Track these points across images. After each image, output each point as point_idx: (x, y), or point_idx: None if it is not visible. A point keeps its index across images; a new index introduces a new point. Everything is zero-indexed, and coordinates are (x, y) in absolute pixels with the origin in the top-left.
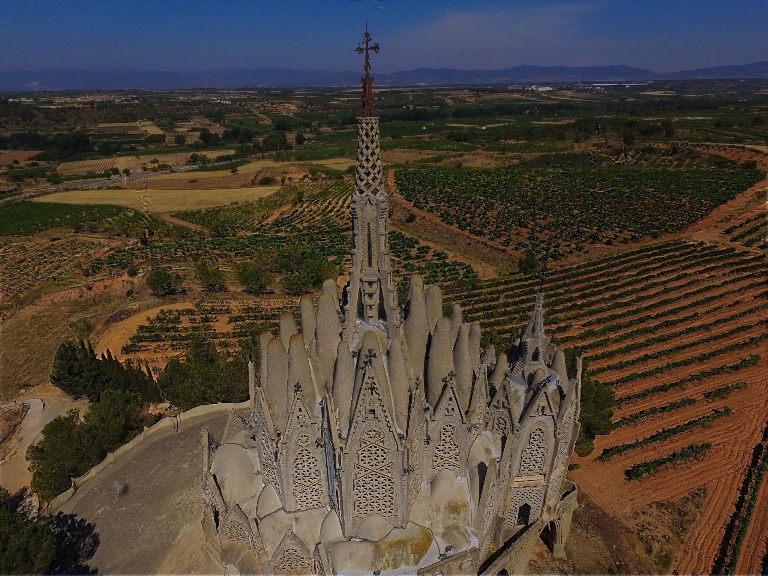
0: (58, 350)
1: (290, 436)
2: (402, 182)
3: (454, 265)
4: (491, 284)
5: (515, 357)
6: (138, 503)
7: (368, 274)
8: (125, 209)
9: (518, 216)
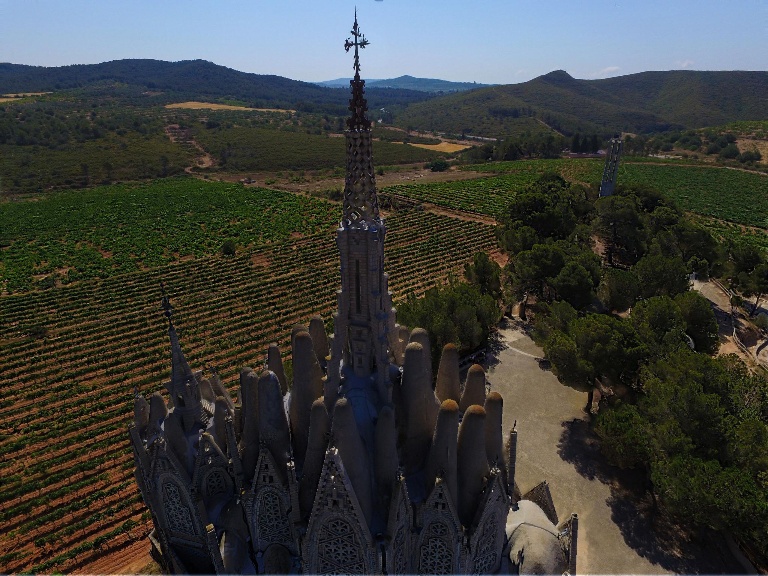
0: None
1: None
2: None
3: None
4: None
5: (184, 435)
6: None
7: None
8: None
9: None
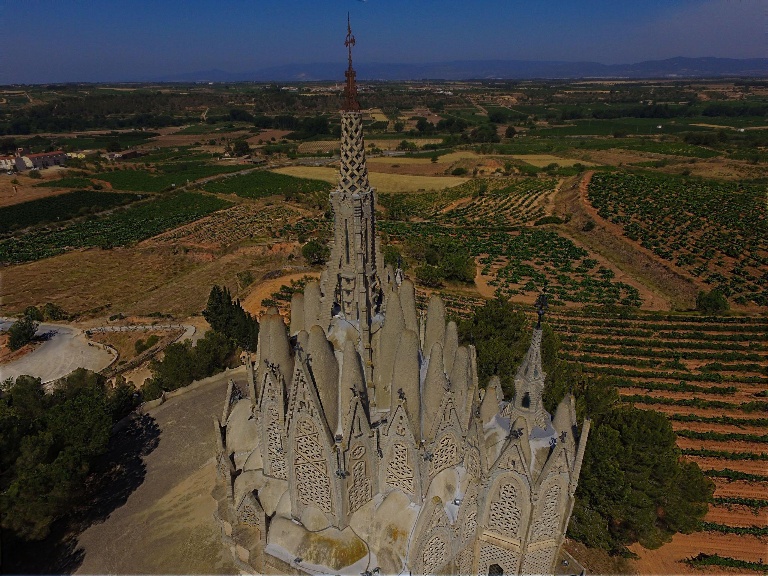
0: (212, 292)
1: (263, 406)
2: (596, 186)
3: (617, 286)
4: (648, 316)
5: None
6: (195, 426)
7: (346, 271)
8: (325, 185)
9: (730, 242)
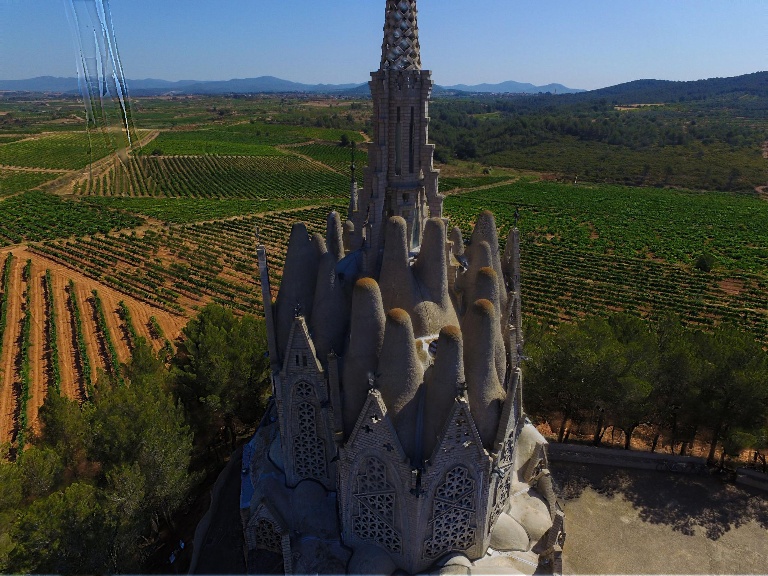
0: None
1: None
2: None
3: None
4: None
5: None
6: None
7: None
8: None
9: None
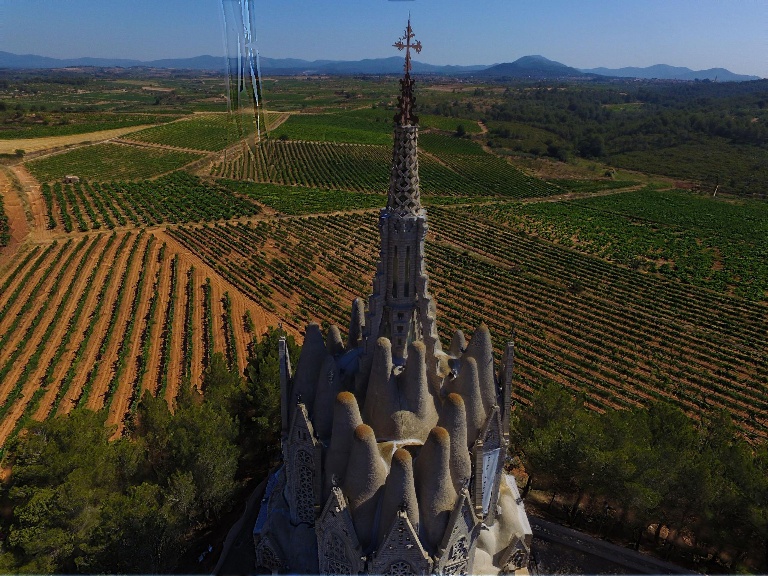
0: None
1: None
2: None
3: None
4: None
5: None
6: None
7: None
8: None
9: None
